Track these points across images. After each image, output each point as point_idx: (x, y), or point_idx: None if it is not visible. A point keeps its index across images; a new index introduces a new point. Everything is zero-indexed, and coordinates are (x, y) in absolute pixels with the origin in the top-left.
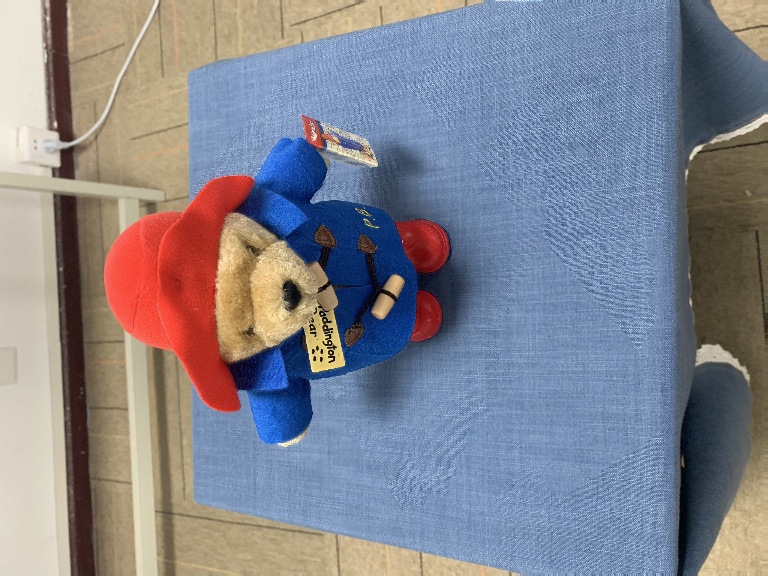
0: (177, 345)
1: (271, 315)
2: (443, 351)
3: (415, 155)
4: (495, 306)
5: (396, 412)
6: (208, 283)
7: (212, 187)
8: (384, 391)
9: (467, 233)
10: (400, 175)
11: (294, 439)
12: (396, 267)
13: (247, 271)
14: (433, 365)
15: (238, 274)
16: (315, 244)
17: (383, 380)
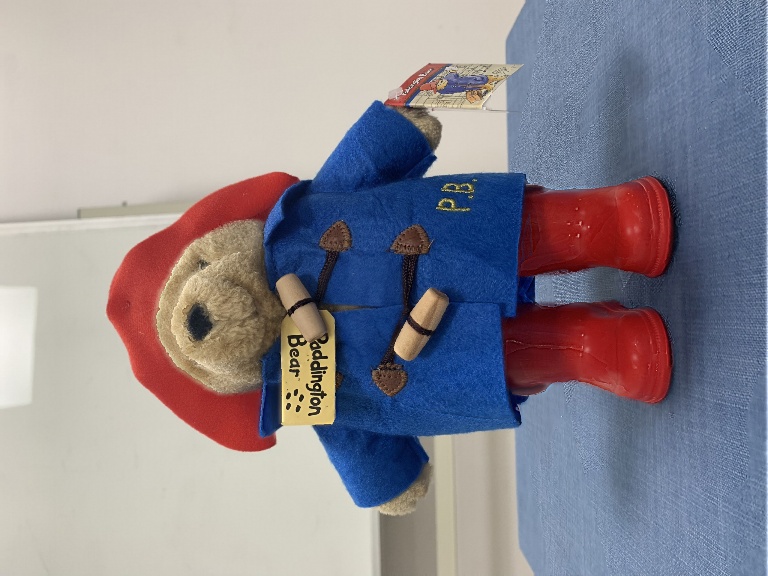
0: (134, 369)
1: (181, 345)
2: (675, 431)
3: (640, 59)
4: (738, 353)
5: (633, 520)
6: (154, 305)
7: (215, 195)
8: (622, 478)
9: (698, 192)
10: (627, 103)
11: (380, 508)
12: (468, 274)
13: (178, 291)
14: (666, 454)
15: (168, 295)
16: (315, 249)
17: (620, 459)
